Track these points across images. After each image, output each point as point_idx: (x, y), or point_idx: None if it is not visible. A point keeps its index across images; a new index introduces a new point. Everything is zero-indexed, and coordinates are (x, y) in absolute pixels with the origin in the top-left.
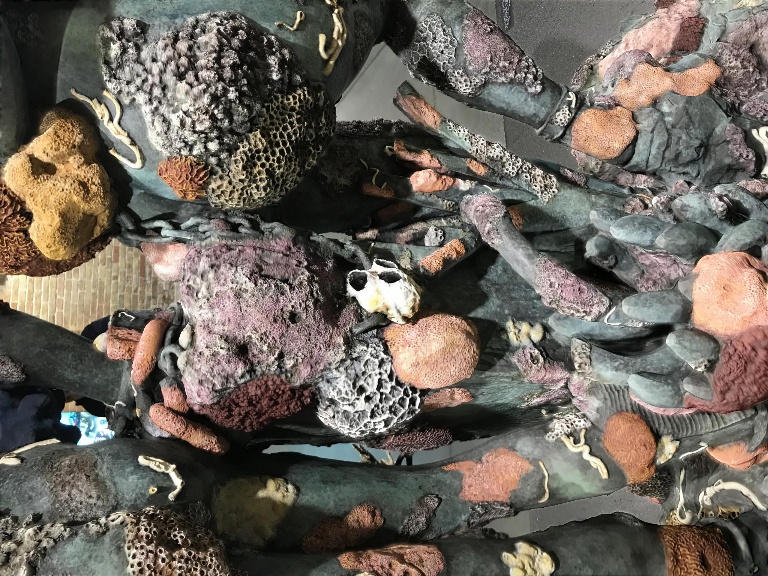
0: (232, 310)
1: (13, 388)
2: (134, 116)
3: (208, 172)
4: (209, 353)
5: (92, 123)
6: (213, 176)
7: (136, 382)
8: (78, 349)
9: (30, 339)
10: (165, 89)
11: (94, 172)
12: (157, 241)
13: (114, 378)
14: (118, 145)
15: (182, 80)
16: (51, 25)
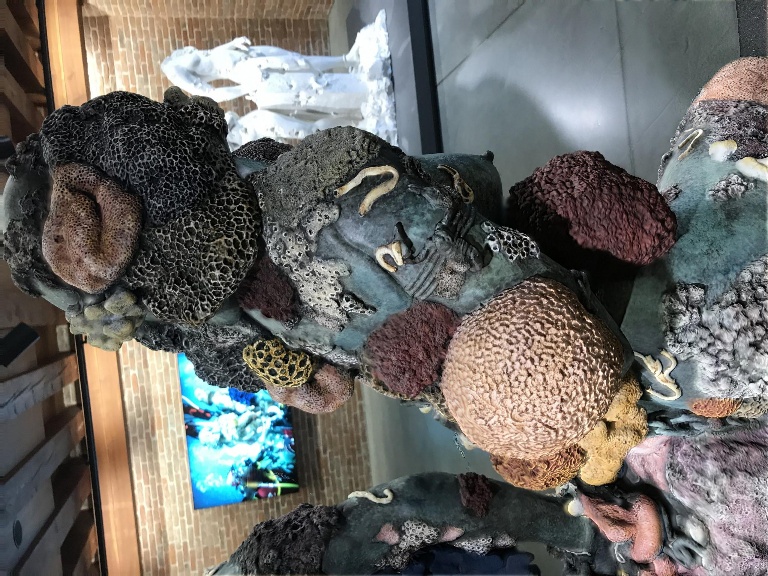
0: (758, 518)
1: (502, 552)
2: (686, 368)
3: (742, 402)
4: (744, 561)
5: (637, 371)
6: (744, 403)
7: (638, 561)
8: (551, 513)
9: (520, 515)
10: (735, 354)
11: (644, 418)
12: (650, 437)
13: (579, 533)
14: (657, 385)
15: (758, 348)
16: (616, 298)
